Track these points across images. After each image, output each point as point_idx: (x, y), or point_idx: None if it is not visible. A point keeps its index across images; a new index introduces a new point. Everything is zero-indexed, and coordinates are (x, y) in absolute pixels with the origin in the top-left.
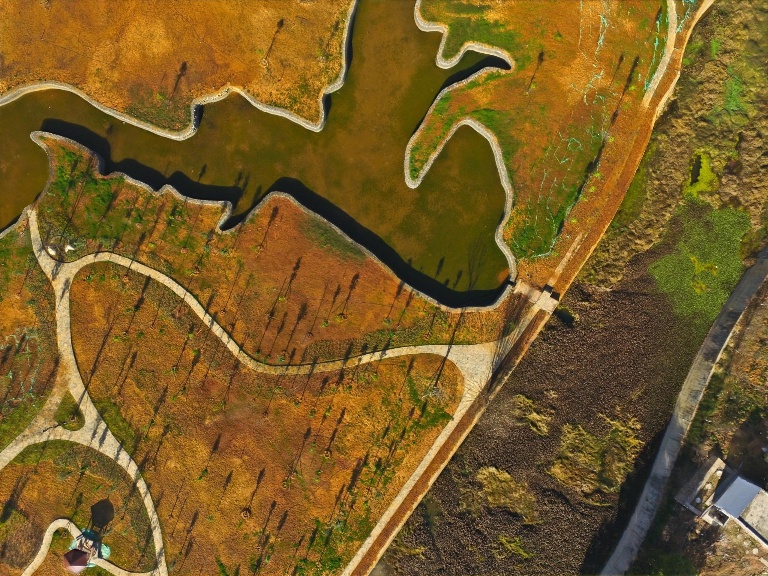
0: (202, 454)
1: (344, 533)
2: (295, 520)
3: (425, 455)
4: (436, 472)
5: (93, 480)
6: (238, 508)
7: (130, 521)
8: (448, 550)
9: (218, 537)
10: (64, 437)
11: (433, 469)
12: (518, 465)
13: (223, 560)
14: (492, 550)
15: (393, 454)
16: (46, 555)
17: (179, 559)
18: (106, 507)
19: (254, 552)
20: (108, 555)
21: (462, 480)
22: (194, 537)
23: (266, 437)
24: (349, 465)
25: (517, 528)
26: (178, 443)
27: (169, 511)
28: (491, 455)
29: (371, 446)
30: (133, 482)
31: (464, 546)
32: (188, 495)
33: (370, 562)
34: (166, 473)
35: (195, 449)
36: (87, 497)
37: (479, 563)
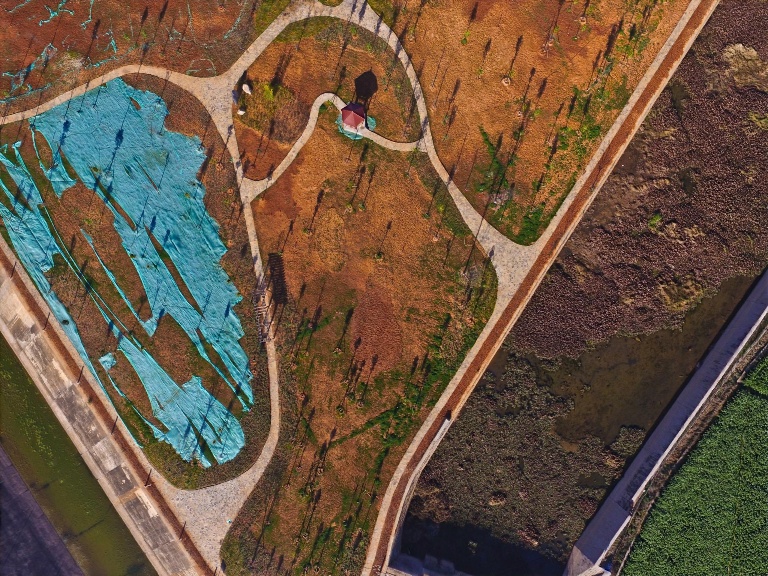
0: (460, 24)
1: (602, 101)
2: (554, 88)
3: (679, 20)
4: (690, 37)
5: (355, 54)
6: (498, 76)
7: (394, 92)
8: (697, 131)
9: (480, 105)
10: (324, 13)
11: (687, 34)
12: (764, 42)
13: (486, 129)
14: (742, 128)
15: (647, 20)
16: (314, 129)
17: (443, 128)
18: (369, 79)
19: (516, 120)
20: (374, 127)
21: (707, 61)
22: (457, 106)
23: (522, 5)
24: (604, 31)
25: (766, 105)
26: (436, 14)
27: (431, 81)
28: (736, 33)
29: (625, 12)
30: (394, 54)
31: (713, 126)
32: (449, 65)
33: (629, 130)
34: (426, 44)
35: (453, 19)
36: (350, 71)
37: (729, 142)
